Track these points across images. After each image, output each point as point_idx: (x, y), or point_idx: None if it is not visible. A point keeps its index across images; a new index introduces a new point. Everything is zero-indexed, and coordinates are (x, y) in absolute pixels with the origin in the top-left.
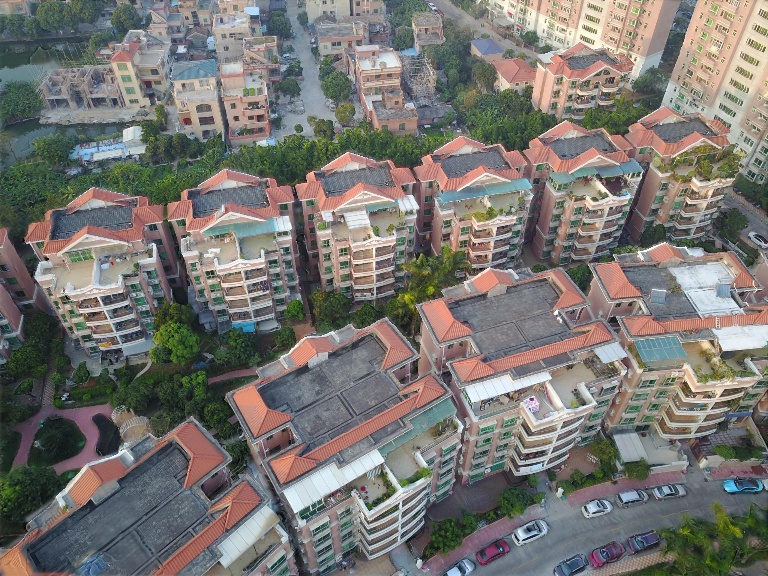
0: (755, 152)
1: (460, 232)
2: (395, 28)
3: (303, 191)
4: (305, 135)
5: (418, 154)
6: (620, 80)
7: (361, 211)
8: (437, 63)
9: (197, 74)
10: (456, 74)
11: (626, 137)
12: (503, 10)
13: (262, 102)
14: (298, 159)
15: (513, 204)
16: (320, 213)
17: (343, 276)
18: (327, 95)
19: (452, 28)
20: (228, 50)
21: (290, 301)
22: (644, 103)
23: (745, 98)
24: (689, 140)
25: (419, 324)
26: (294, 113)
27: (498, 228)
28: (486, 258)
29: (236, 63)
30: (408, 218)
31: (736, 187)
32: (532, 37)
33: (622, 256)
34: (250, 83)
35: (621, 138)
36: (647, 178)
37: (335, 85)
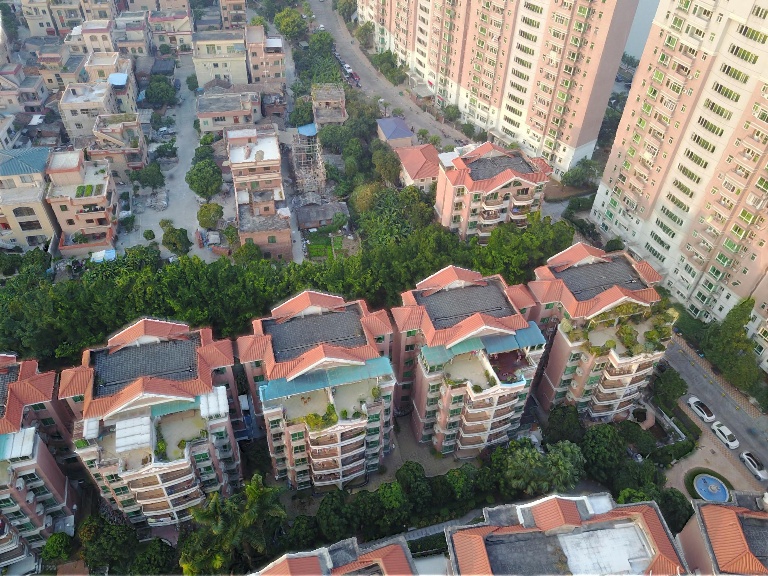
0: (698, 284)
1: (291, 438)
2: (297, 97)
3: (65, 385)
4: (160, 241)
5: (271, 293)
6: (535, 191)
7: (143, 418)
8: (335, 146)
9: (17, 169)
10: (353, 163)
11: (529, 286)
12: (424, 78)
13: (101, 203)
14: (105, 305)
15: (368, 393)
16: (82, 422)
17: (124, 501)
18: (192, 189)
19: (356, 103)
20: (81, 128)
21: (49, 536)
22: (572, 204)
23: (685, 218)
24: (607, 297)
25: (228, 573)
26: (154, 209)
27: (342, 433)
28: (335, 462)
29: (74, 152)
30: (215, 422)
31: (676, 326)
32: (453, 112)
33: (495, 511)
34: (91, 177)
35: (520, 292)
36: (555, 342)
37: (201, 178)
